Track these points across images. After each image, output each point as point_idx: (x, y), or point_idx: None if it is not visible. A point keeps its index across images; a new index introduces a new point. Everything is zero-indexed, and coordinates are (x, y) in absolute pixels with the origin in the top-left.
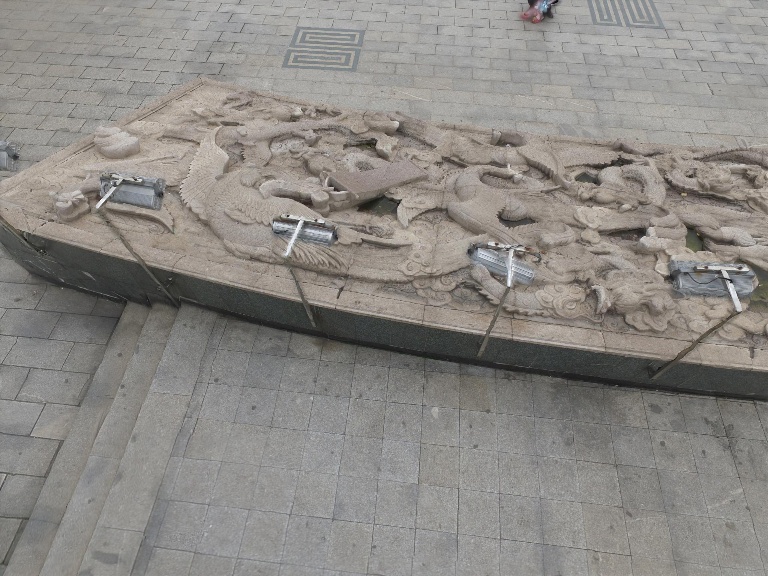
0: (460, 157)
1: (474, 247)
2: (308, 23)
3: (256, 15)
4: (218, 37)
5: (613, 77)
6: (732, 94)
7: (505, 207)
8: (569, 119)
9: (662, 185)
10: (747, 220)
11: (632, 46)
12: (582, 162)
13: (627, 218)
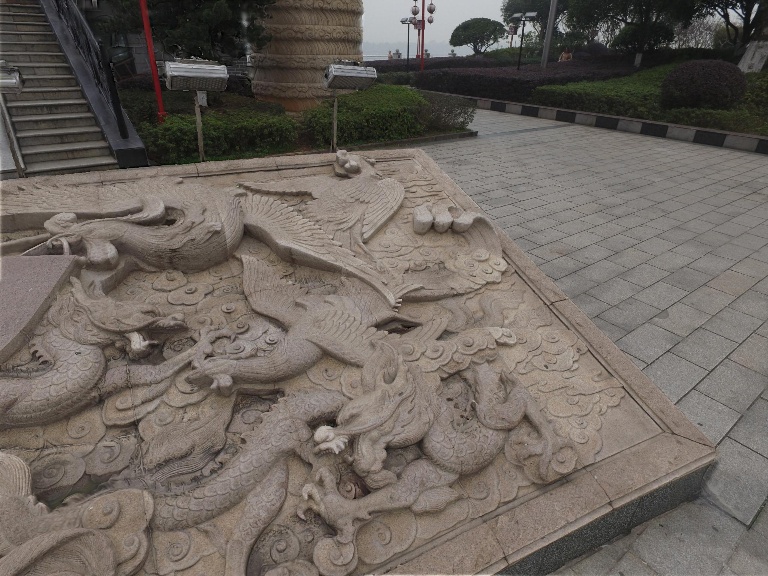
0: None
1: None
2: None
3: None
4: None
5: None
6: None
7: None
8: None
9: None
10: None
11: None
12: None
13: None
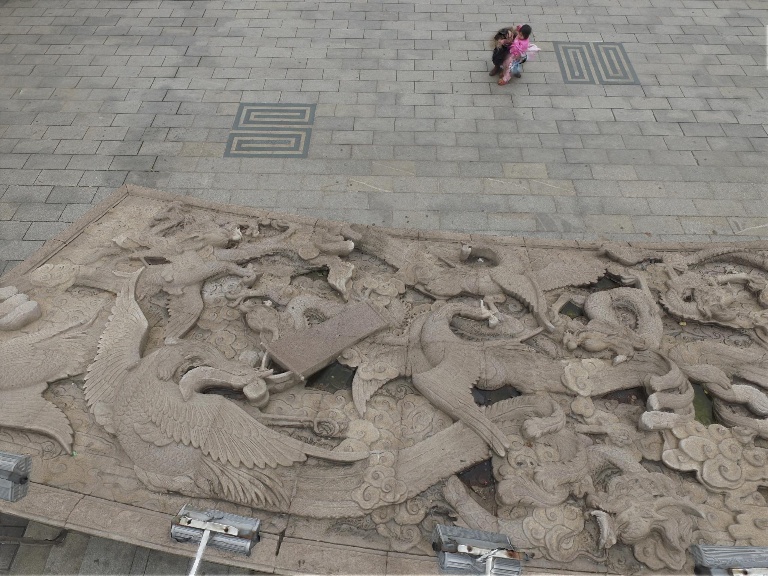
0: (426, 287)
1: (440, 549)
2: (252, 98)
3: (194, 90)
4: (151, 121)
5: (590, 149)
6: (719, 163)
7: (480, 376)
8: (546, 206)
9: (658, 317)
10: (759, 365)
11: (607, 108)
12: (565, 283)
13: (622, 372)
